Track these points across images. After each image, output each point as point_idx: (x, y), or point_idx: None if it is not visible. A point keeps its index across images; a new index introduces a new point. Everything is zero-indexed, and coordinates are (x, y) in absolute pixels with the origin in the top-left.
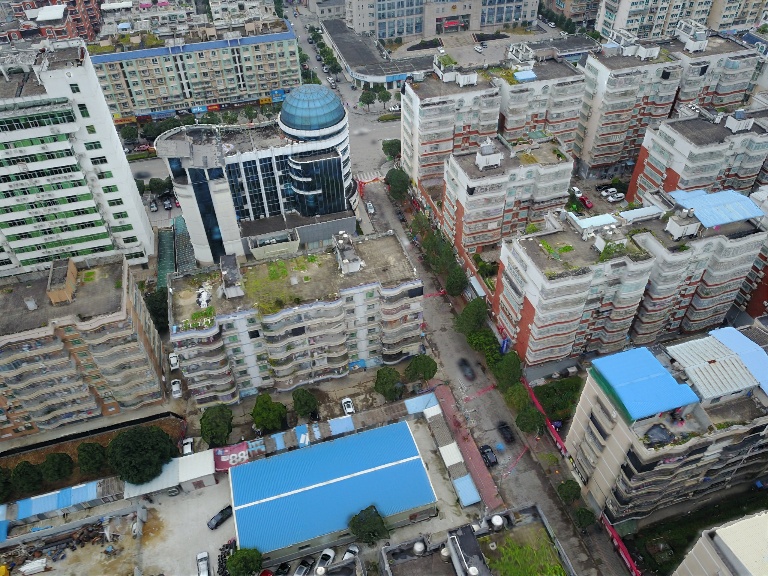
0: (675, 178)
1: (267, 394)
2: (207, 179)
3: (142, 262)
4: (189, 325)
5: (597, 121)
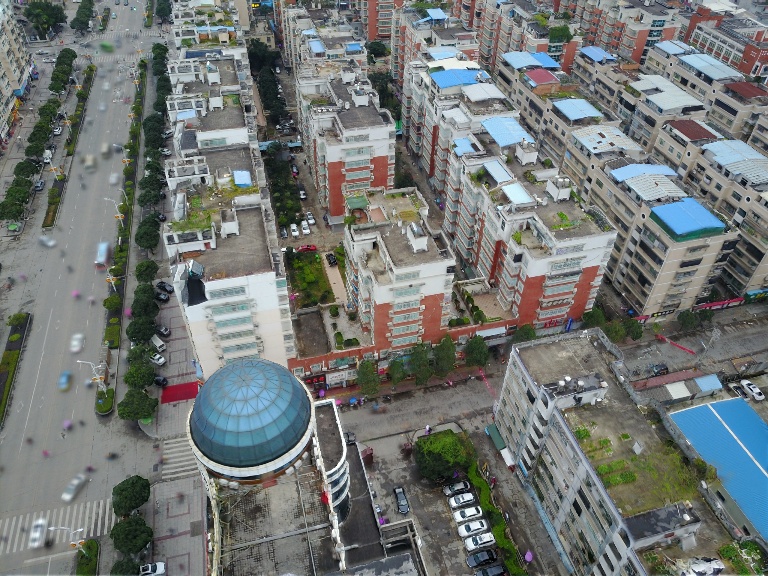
0: (383, 161)
1: None
2: None
3: None
4: None
5: None
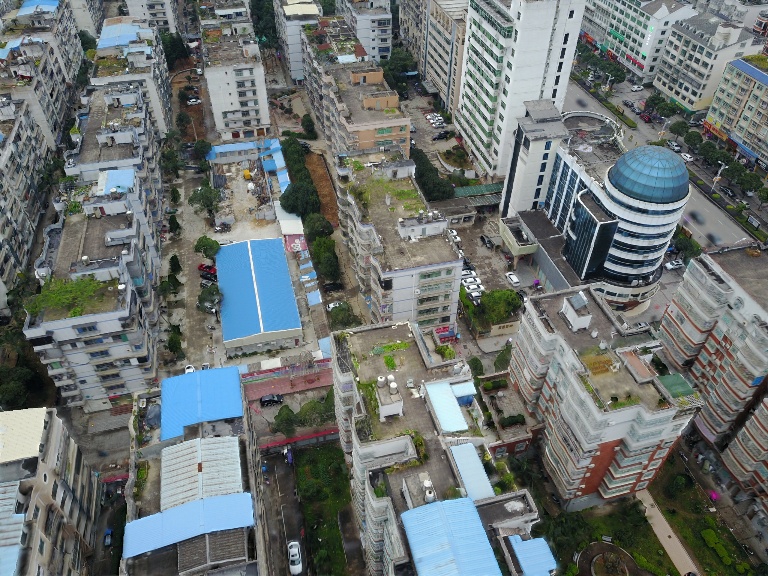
0: None
1: (333, 243)
2: (522, 142)
3: (489, 173)
4: (347, 161)
5: None
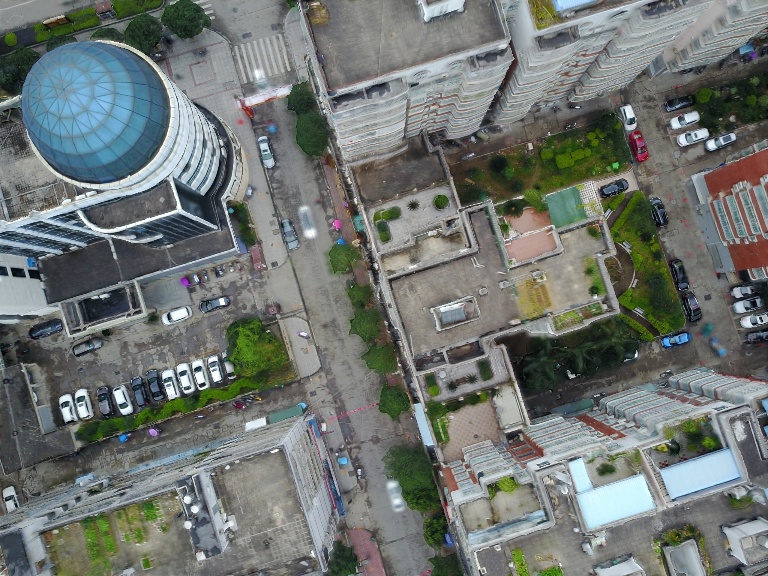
0: None
1: None
2: None
3: None
4: None
5: (712, 19)
